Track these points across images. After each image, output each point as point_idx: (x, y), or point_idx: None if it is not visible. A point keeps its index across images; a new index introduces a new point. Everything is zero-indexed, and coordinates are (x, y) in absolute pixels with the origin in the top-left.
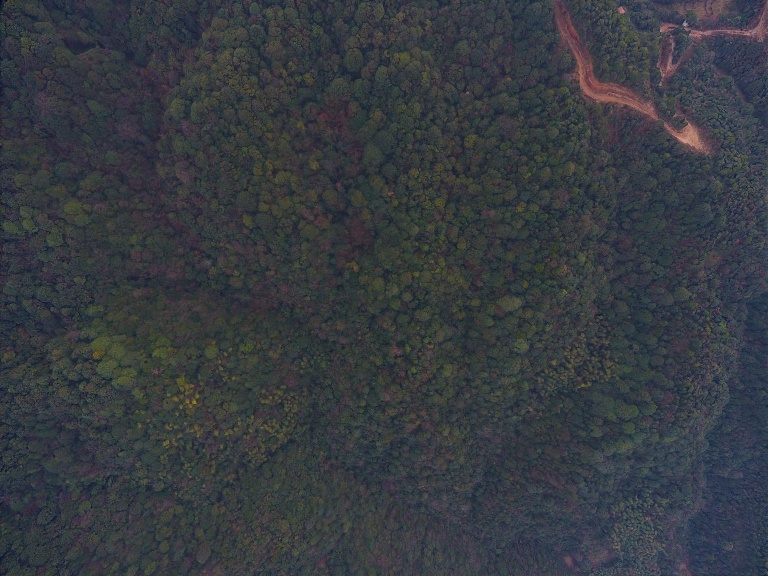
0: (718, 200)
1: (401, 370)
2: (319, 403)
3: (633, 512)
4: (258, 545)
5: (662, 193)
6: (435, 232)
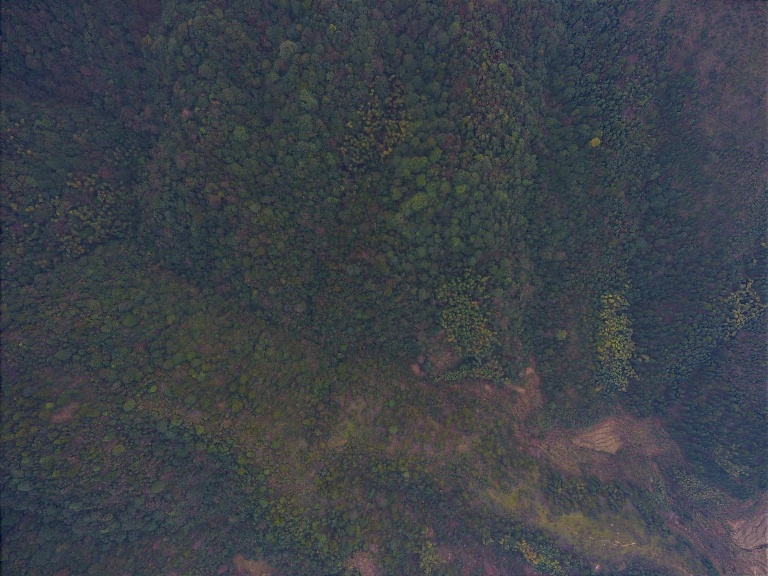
0: None
1: (192, 133)
2: None
3: (459, 297)
4: (63, 318)
5: None
6: None
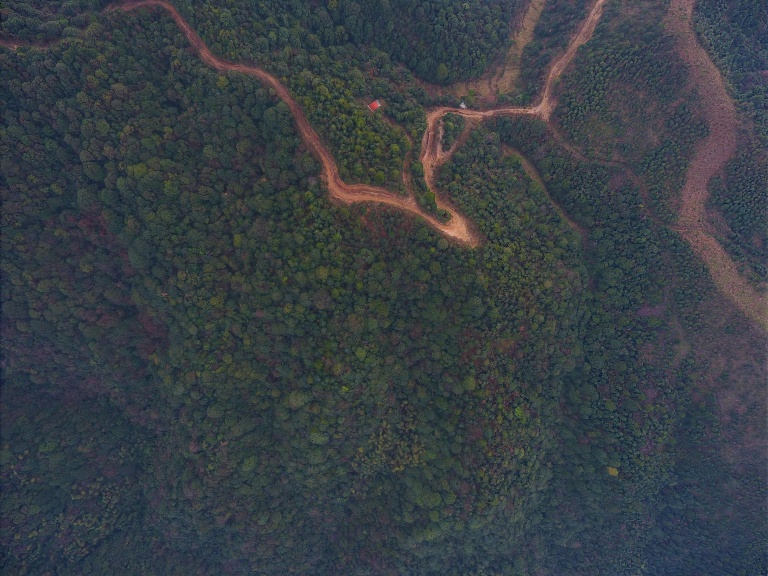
0: (489, 292)
1: (200, 466)
2: (143, 491)
3: None
4: None
5: (437, 285)
6: (219, 329)
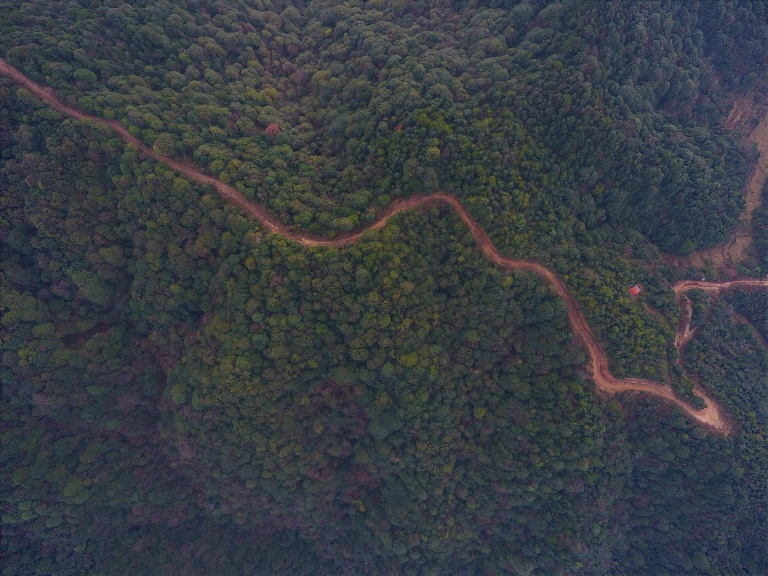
0: (739, 480)
1: None
2: None
3: None
4: None
5: (680, 466)
6: (444, 491)
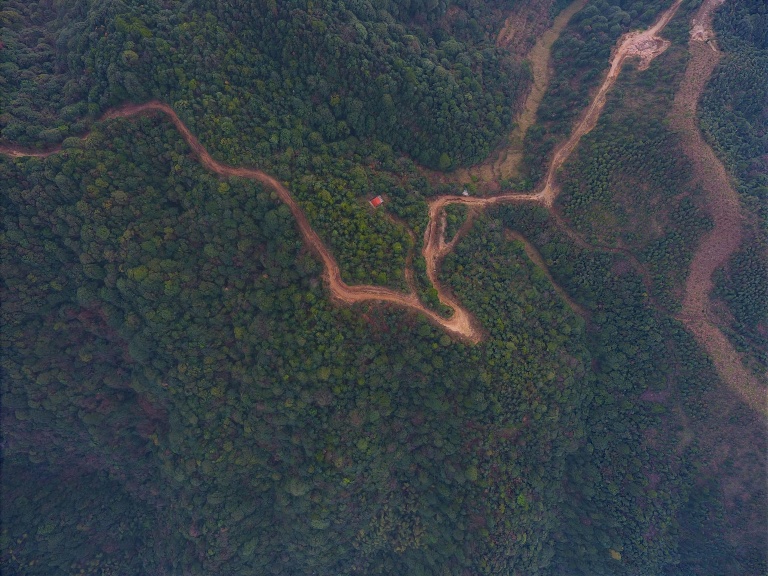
0: (492, 387)
1: (200, 550)
2: (143, 565)
3: None
4: None
5: (439, 378)
6: (219, 416)
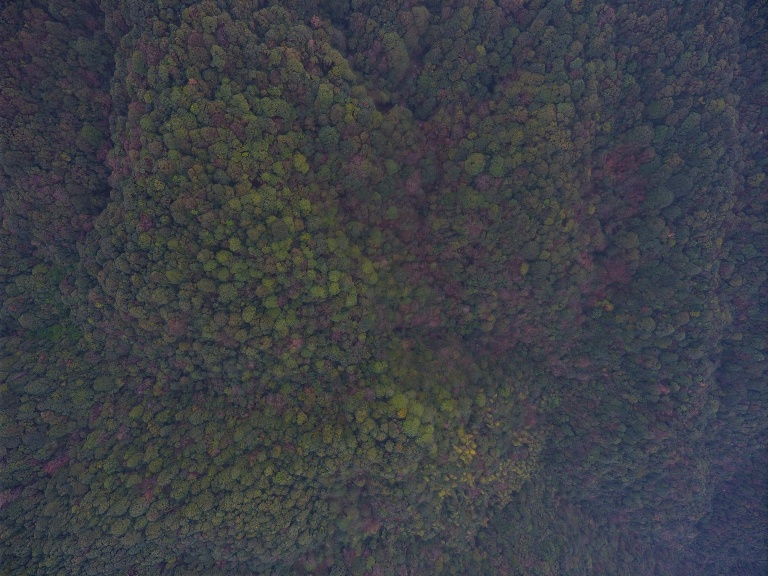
0: None
1: (668, 408)
2: (556, 440)
3: None
4: None
5: None
6: None
